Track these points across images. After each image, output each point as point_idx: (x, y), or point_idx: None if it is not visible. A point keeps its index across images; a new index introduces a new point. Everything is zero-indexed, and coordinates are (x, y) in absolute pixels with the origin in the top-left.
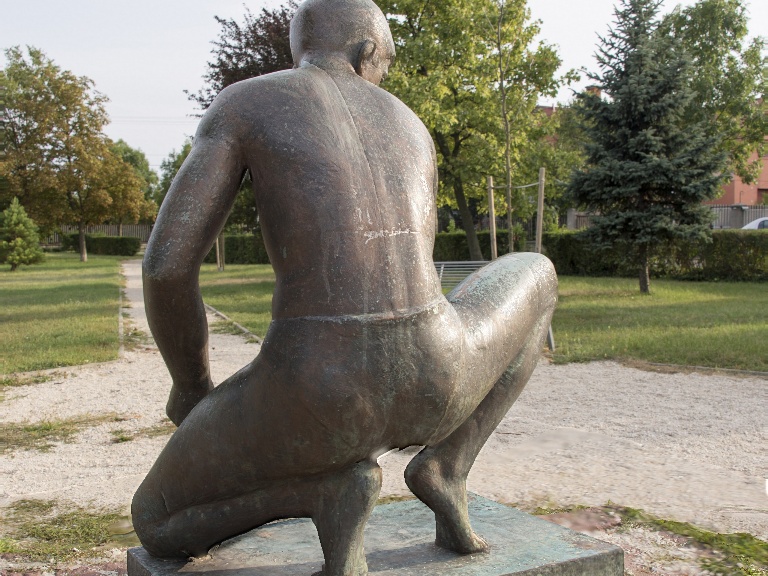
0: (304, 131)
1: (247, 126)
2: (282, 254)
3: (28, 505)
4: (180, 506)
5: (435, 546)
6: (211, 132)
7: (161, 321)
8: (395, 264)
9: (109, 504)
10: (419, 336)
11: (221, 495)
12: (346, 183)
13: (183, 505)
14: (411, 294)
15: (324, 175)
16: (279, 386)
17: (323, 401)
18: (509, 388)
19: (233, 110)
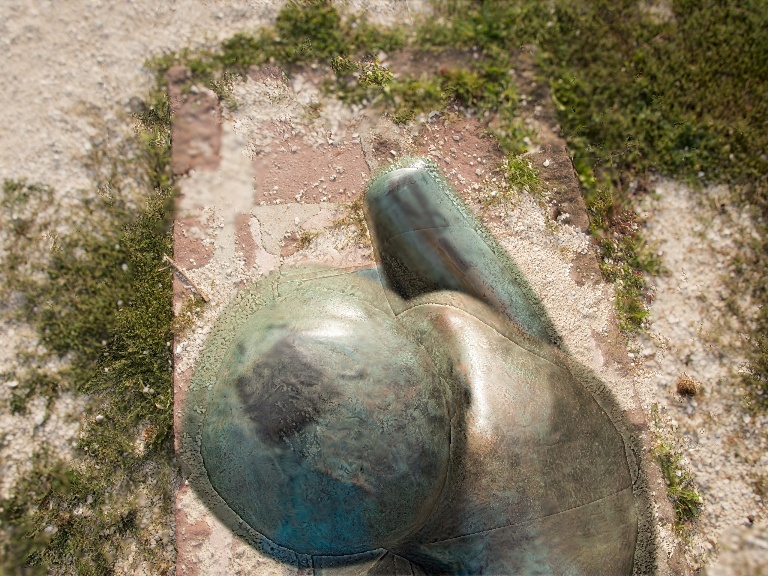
0: None
1: None
2: None
3: None
4: None
5: None
6: None
7: None
8: None
9: None
10: None
11: None
12: None
13: None
14: None
15: None
16: None
17: None
18: None
19: None
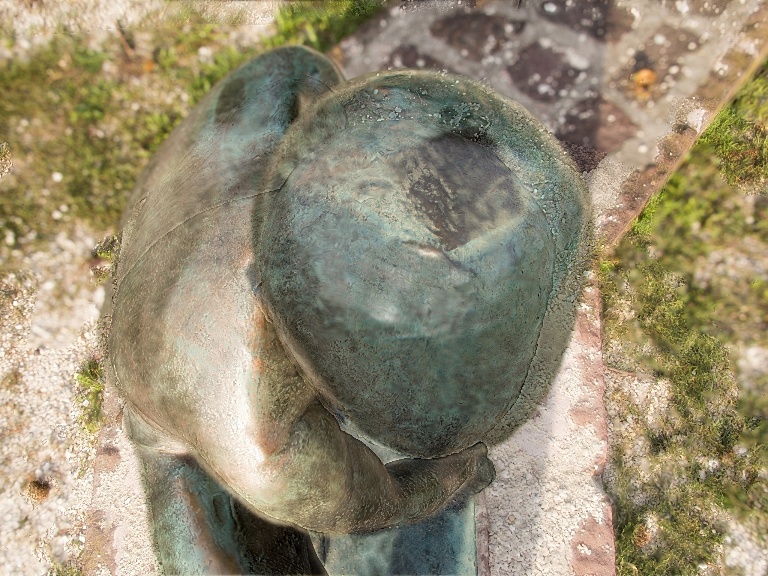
0: None
1: None
2: None
3: None
4: None
5: None
6: None
7: None
8: None
9: None
10: None
11: None
12: None
13: None
14: None
15: None
16: None
17: None
18: None
19: None
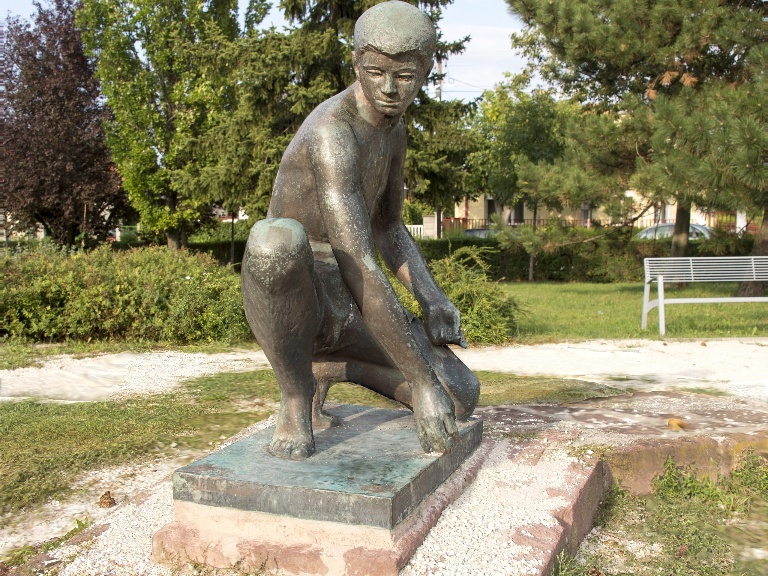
0: None
1: None
2: None
3: None
4: None
5: None
6: None
7: None
8: None
9: None
10: None
11: None
12: None
13: None
14: None
15: None
16: None
17: None
18: None
19: None
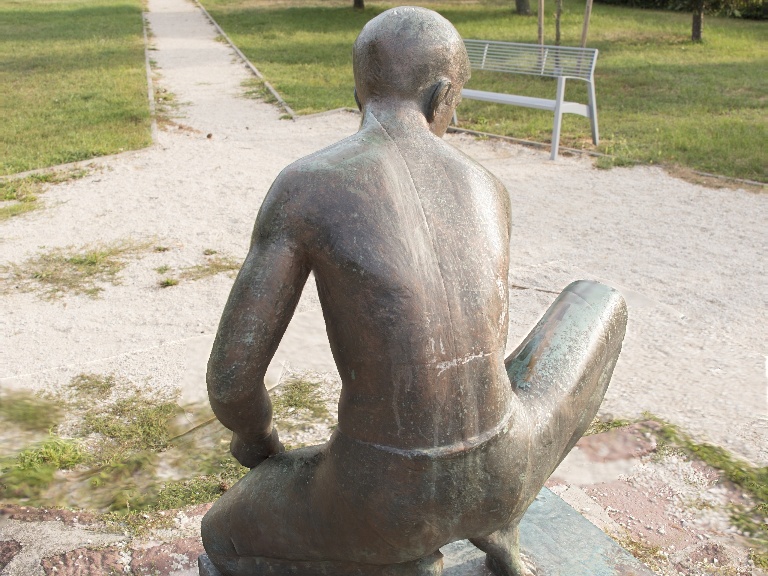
0: (374, 249)
1: (312, 232)
2: (350, 375)
3: (88, 384)
4: (249, 554)
5: (485, 568)
6: (273, 236)
7: (227, 421)
8: (467, 393)
9: (164, 386)
10: (488, 461)
11: (289, 559)
12: (419, 311)
13: (252, 555)
14: (482, 421)
15: (396, 303)
16: (347, 506)
17: (391, 528)
18: (569, 443)
19: (296, 212)
